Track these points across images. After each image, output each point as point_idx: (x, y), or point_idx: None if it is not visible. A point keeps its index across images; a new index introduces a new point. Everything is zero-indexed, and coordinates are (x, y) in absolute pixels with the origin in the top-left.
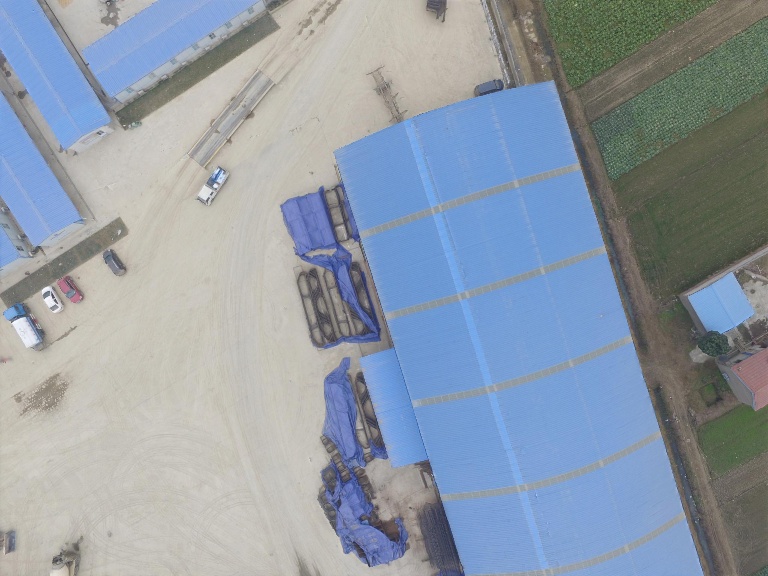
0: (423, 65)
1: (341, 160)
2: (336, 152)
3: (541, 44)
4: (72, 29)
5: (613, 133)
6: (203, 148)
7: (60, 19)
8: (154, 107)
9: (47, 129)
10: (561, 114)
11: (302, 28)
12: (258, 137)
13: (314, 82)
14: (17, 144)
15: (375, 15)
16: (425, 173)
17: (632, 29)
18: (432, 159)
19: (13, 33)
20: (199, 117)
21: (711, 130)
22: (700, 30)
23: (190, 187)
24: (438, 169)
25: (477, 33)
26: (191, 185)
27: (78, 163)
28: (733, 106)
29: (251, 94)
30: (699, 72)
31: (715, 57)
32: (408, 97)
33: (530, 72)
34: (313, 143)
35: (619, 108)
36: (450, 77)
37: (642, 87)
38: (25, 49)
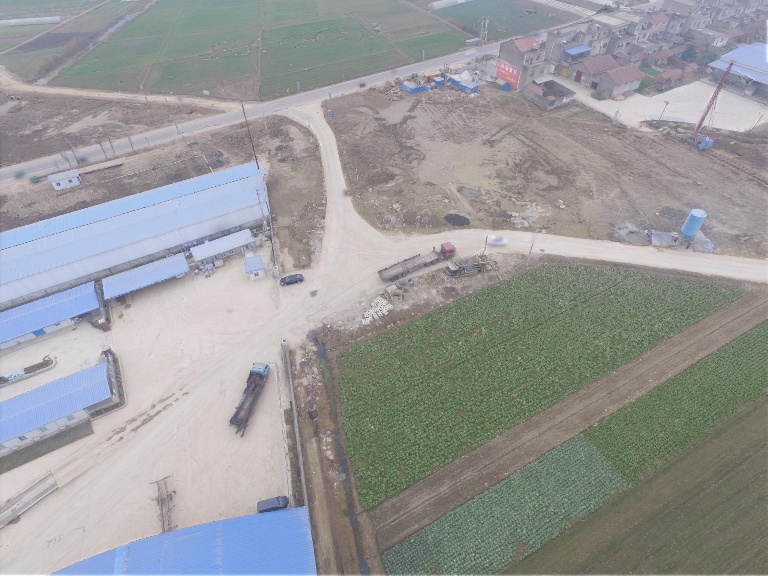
0: (215, 476)
1: None
2: None
3: (337, 461)
4: None
5: (406, 568)
6: None
7: None
8: None
9: None
10: (308, 547)
11: (114, 434)
12: (8, 547)
13: (100, 487)
14: None
15: (185, 426)
16: None
17: (425, 452)
18: None
19: None
20: None
21: (521, 571)
22: (493, 456)
23: None
24: None
25: (275, 448)
26: None
27: None
28: (540, 542)
29: (28, 497)
30: (497, 500)
31: (511, 485)
32: (188, 509)
33: (322, 489)
34: (64, 559)
35: (414, 536)
36: (238, 490)
37: (438, 513)
38: None
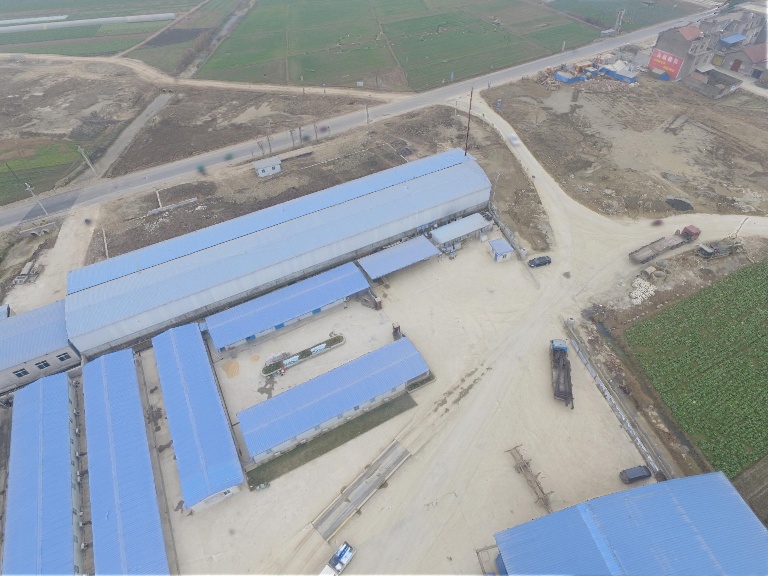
0: (559, 446)
1: (504, 546)
2: (497, 535)
3: (673, 434)
4: (230, 395)
5: None
6: (330, 518)
7: (223, 387)
8: (286, 469)
9: (172, 484)
10: (747, 509)
11: (438, 406)
12: (390, 509)
13: (450, 455)
14: (140, 498)
15: (505, 400)
16: (617, 572)
17: (761, 426)
18: (622, 554)
19: (183, 395)
20: (330, 483)
21: None
22: None
23: (307, 565)
24: (633, 568)
25: (606, 420)
26: (308, 563)
27: (190, 525)
28: None
29: (387, 463)
30: None
31: None
32: (549, 477)
33: (672, 460)
34: (451, 521)
35: None
36: (590, 460)
37: None
38: (188, 409)
